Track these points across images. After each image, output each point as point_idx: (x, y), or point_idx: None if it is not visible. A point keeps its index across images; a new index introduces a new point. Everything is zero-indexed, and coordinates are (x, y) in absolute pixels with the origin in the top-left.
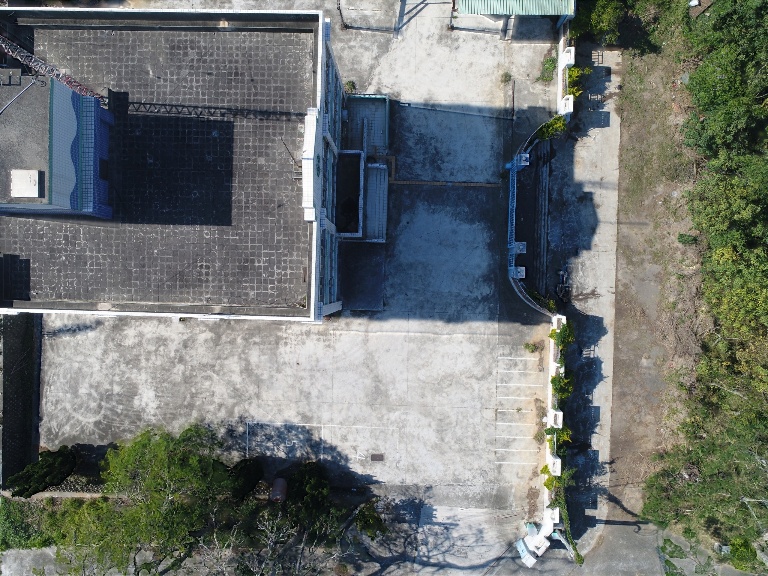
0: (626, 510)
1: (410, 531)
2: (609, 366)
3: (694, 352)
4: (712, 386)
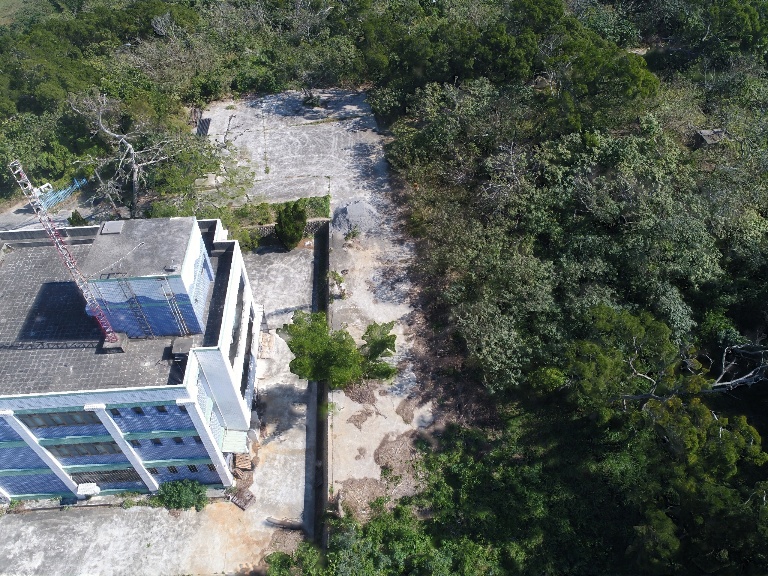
0: None
1: None
2: None
3: None
4: None
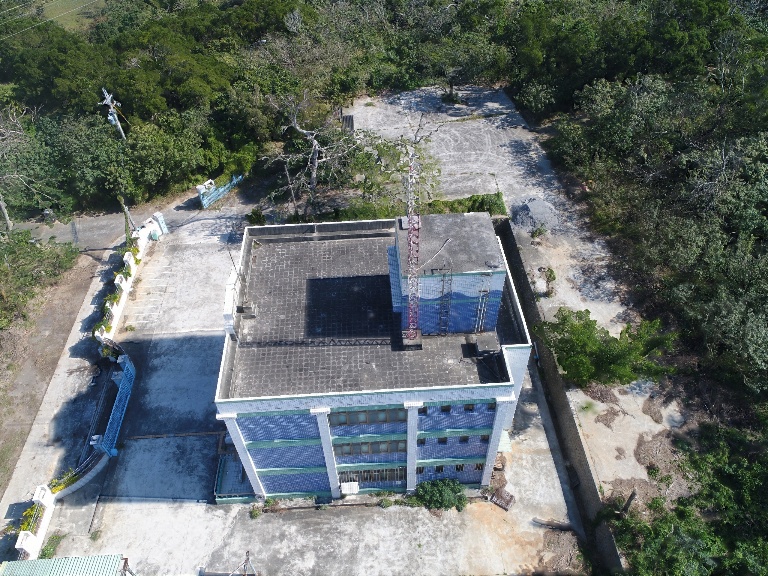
0: (91, 256)
1: (236, 230)
2: (75, 329)
3: (6, 333)
4: (2, 319)
